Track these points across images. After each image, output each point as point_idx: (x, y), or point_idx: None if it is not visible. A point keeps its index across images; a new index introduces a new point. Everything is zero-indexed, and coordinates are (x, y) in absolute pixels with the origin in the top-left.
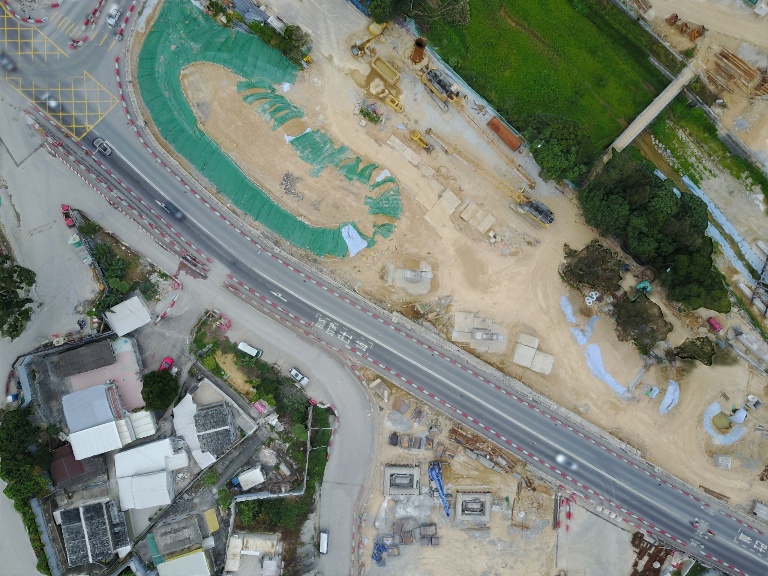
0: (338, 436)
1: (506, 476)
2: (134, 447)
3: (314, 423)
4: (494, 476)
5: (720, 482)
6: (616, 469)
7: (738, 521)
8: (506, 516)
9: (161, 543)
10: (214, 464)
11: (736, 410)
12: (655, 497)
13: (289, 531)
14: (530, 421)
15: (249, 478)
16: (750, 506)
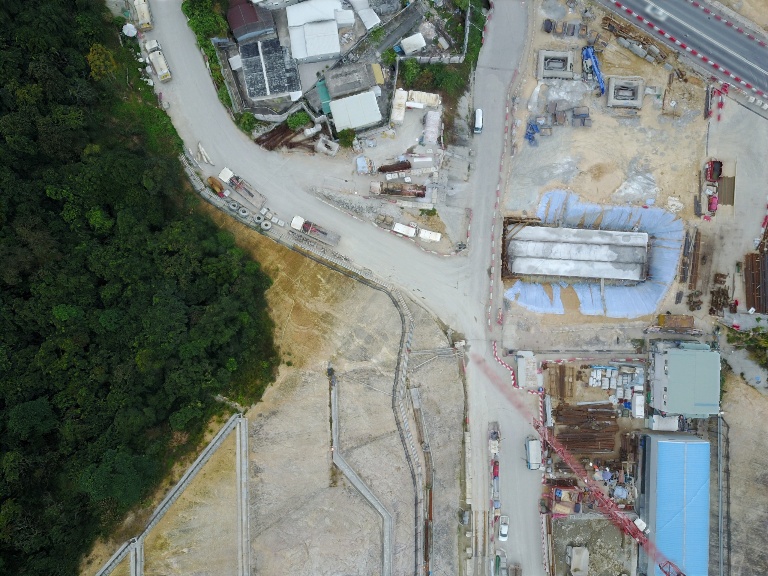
0: (492, 23)
1: (658, 67)
2: (304, 1)
3: (470, 7)
4: (646, 67)
5: None
6: None
7: None
8: (657, 106)
9: (332, 85)
10: (377, 31)
11: None
12: None
13: (449, 97)
14: (683, 14)
15: (411, 41)
16: None
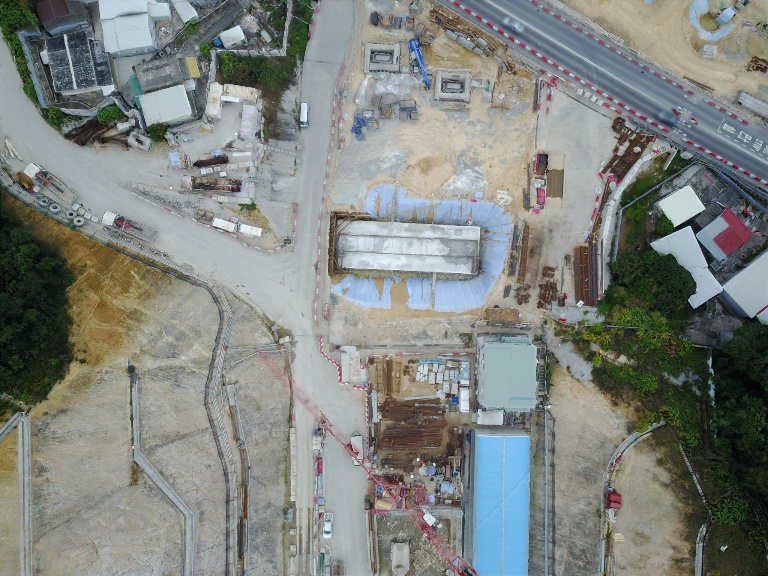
0: (319, 16)
1: (487, 60)
2: None
3: (296, 0)
4: (475, 60)
5: (705, 73)
6: (598, 56)
7: (722, 109)
8: (486, 99)
9: (143, 78)
10: (196, 24)
11: (724, 9)
12: (637, 84)
13: (269, 90)
14: (512, 6)
15: (230, 35)
16: (735, 96)
